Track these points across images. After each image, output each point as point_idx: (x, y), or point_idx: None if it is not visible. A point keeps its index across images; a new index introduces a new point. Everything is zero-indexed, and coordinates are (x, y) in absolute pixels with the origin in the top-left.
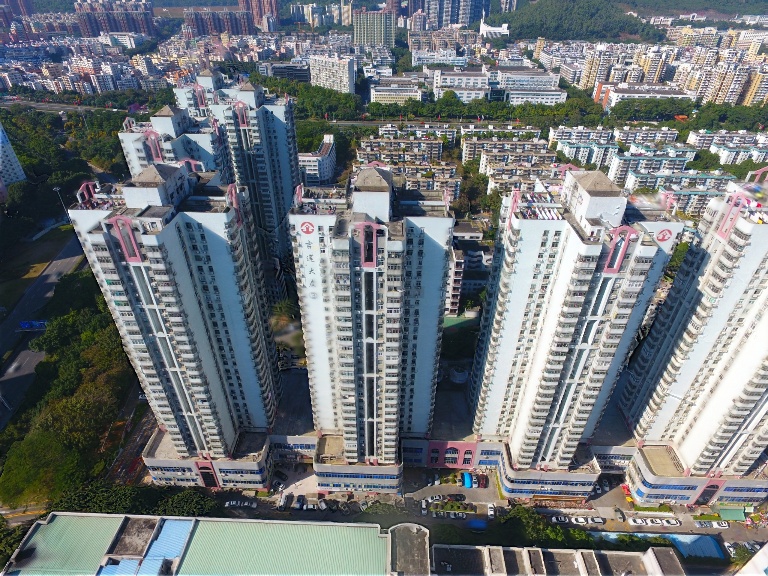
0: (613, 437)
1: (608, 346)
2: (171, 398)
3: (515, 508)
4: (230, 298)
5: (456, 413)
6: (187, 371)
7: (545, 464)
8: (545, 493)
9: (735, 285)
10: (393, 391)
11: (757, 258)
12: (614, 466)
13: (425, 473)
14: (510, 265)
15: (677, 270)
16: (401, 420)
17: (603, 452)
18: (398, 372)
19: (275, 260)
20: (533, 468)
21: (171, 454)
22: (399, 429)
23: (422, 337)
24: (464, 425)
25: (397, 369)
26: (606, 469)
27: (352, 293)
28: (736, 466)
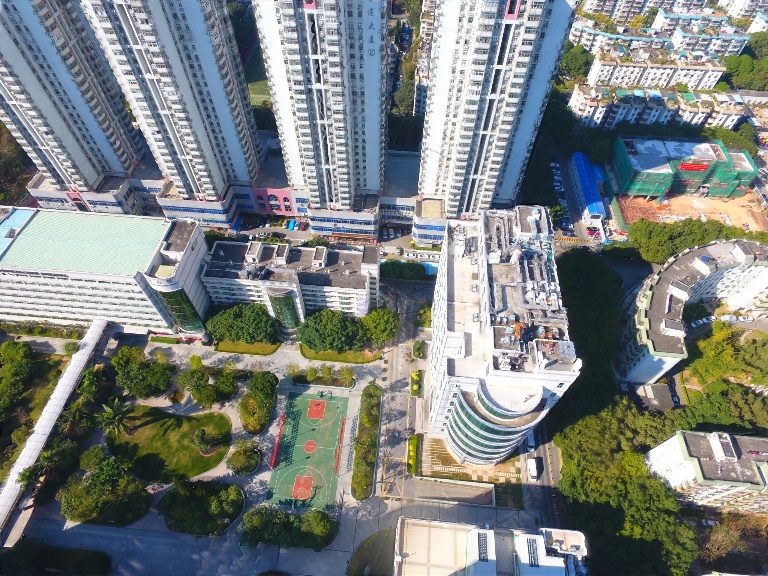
0: (404, 193)
1: (334, 85)
2: (23, 131)
3: (313, 239)
4: (42, 39)
5: (285, 172)
6: (21, 103)
7: (333, 205)
8: (341, 231)
9: (446, 34)
10: (187, 128)
11: (456, 5)
12: (404, 217)
13: (260, 219)
14: (255, 9)
15: (566, 74)
16: (226, 168)
17: (391, 203)
18: (183, 108)
19: (81, 8)
20: (325, 208)
21: (50, 188)
22: (228, 177)
23: (211, 84)
24: (287, 180)
25: (180, 105)
26: (398, 219)
27: (115, 26)
28: (478, 210)
